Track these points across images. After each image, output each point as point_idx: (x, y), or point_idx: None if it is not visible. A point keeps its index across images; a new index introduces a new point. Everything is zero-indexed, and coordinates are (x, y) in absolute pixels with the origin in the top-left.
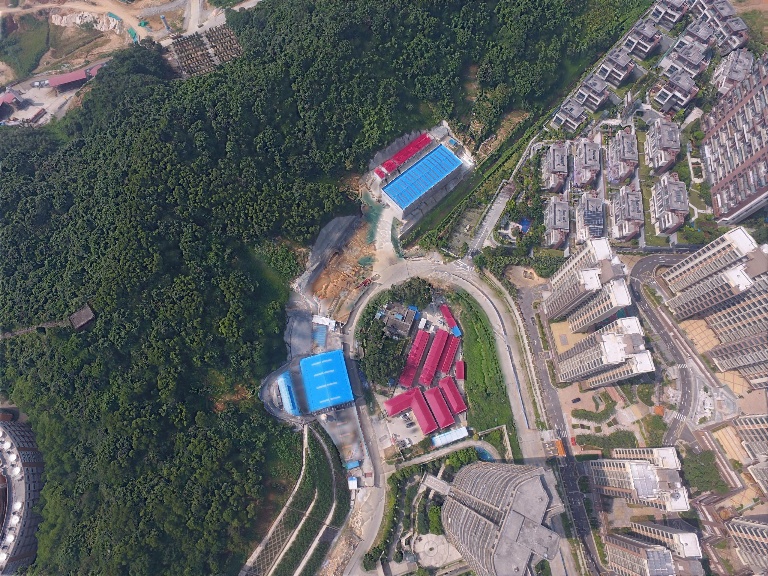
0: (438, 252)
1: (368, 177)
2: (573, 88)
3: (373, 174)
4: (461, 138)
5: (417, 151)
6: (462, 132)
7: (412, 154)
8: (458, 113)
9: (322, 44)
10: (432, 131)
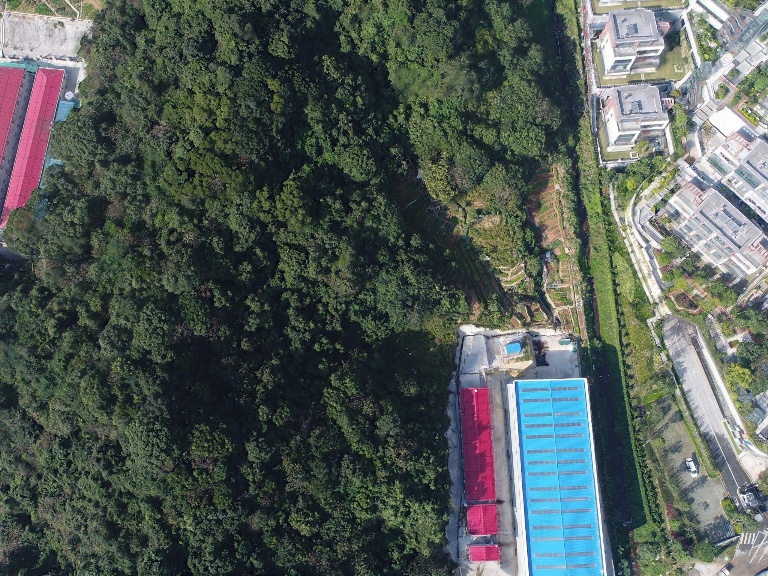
0: (701, 562)
1: (462, 571)
2: (570, 48)
3: (470, 562)
4: (515, 324)
5: (490, 436)
6: (506, 312)
7: (490, 452)
8: (469, 289)
9: (159, 492)
10: (464, 366)
